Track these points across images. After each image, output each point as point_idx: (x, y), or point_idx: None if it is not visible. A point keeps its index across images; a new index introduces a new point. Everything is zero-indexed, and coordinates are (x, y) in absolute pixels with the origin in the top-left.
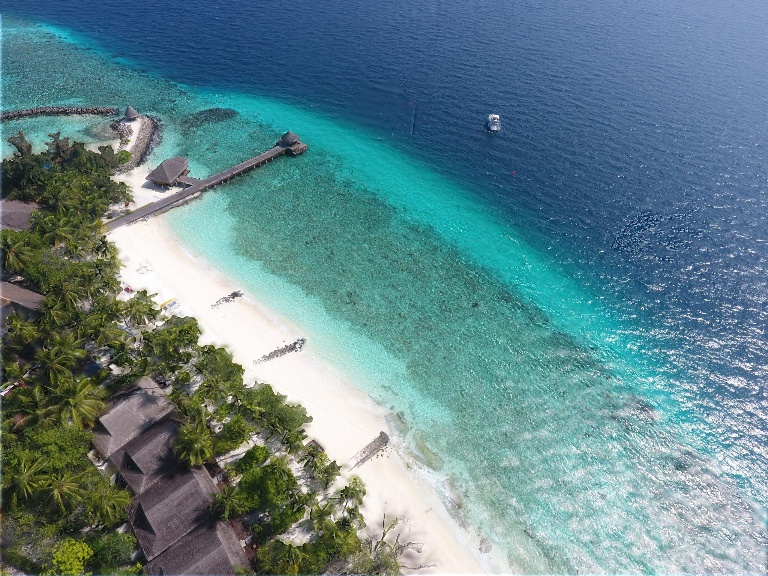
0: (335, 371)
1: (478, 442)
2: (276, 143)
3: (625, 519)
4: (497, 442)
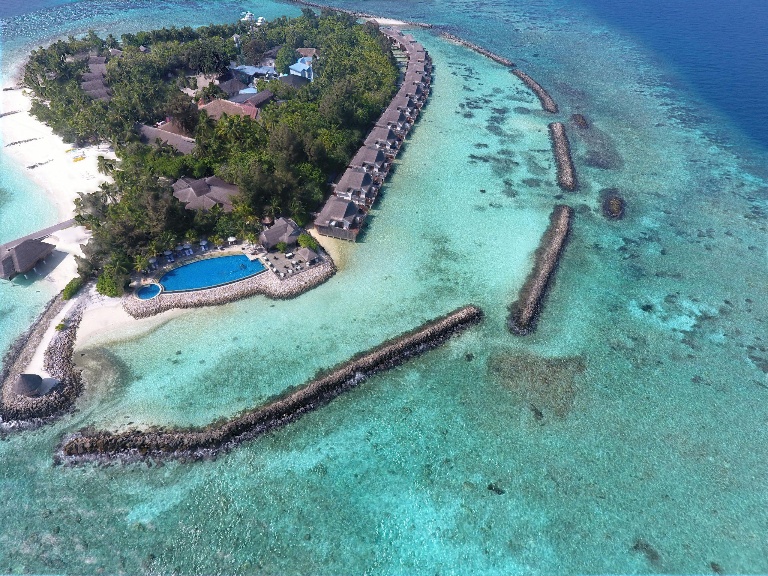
0: (1, 135)
1: None
2: None
3: None
4: None
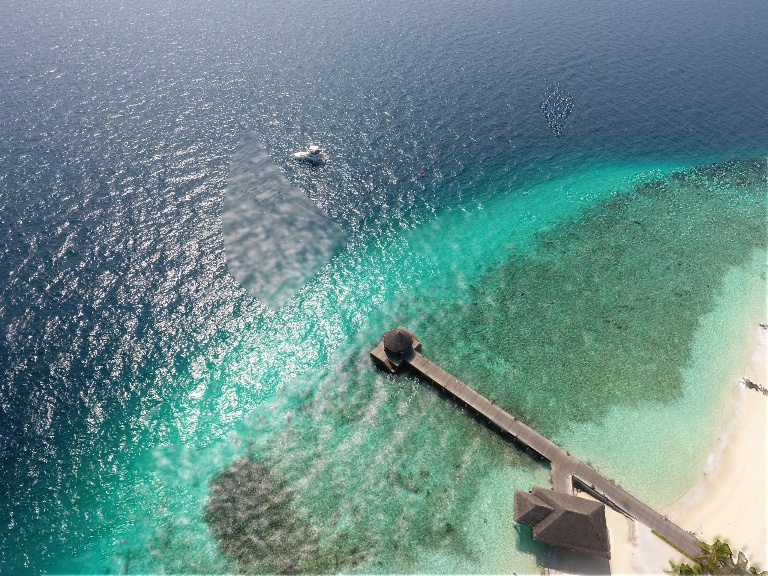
0: None
1: (766, 240)
2: (396, 368)
3: (764, 199)
4: (759, 233)
